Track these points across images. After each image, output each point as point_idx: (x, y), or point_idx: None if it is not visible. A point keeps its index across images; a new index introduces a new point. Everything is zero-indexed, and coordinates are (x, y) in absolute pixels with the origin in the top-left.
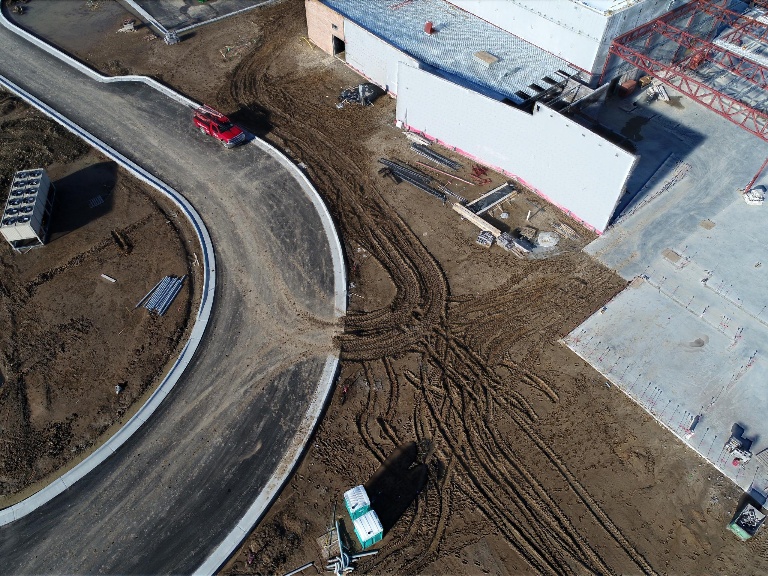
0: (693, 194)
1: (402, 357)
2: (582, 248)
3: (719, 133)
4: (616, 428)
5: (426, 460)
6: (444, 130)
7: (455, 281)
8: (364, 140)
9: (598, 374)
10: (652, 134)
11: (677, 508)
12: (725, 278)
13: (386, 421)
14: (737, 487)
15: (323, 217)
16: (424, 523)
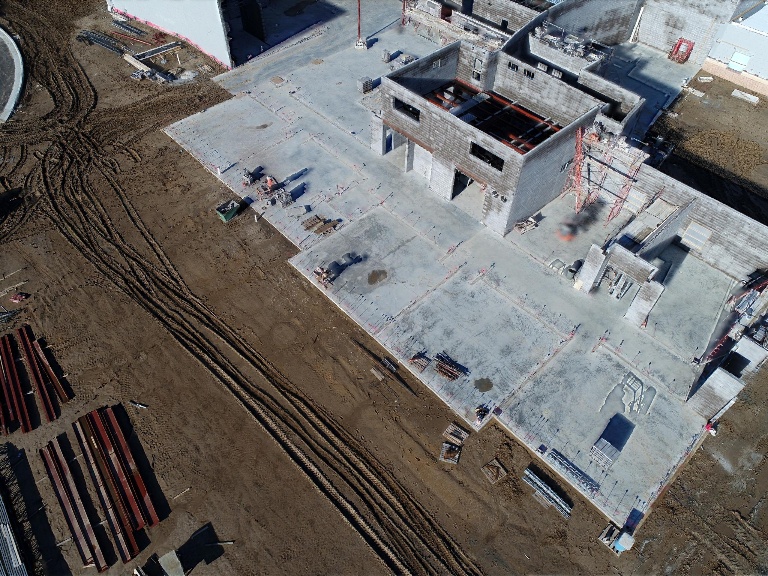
0: (319, 45)
1: (37, 144)
2: (211, 78)
3: (366, 8)
4: (173, 173)
5: (25, 196)
6: (135, 7)
7: (103, 101)
8: (76, 20)
9: (178, 146)
10: (312, 10)
11: (191, 210)
12: (309, 91)
13: (6, 178)
14: (238, 197)
15: (17, 67)
16: (5, 227)
